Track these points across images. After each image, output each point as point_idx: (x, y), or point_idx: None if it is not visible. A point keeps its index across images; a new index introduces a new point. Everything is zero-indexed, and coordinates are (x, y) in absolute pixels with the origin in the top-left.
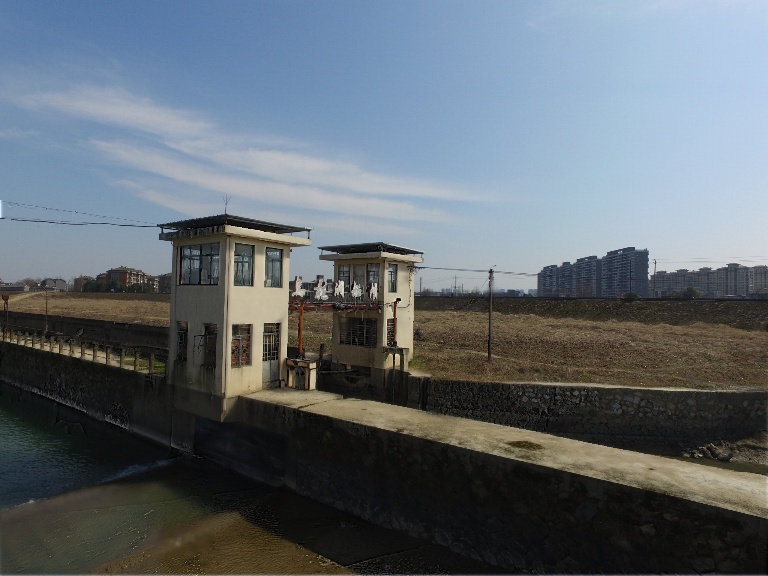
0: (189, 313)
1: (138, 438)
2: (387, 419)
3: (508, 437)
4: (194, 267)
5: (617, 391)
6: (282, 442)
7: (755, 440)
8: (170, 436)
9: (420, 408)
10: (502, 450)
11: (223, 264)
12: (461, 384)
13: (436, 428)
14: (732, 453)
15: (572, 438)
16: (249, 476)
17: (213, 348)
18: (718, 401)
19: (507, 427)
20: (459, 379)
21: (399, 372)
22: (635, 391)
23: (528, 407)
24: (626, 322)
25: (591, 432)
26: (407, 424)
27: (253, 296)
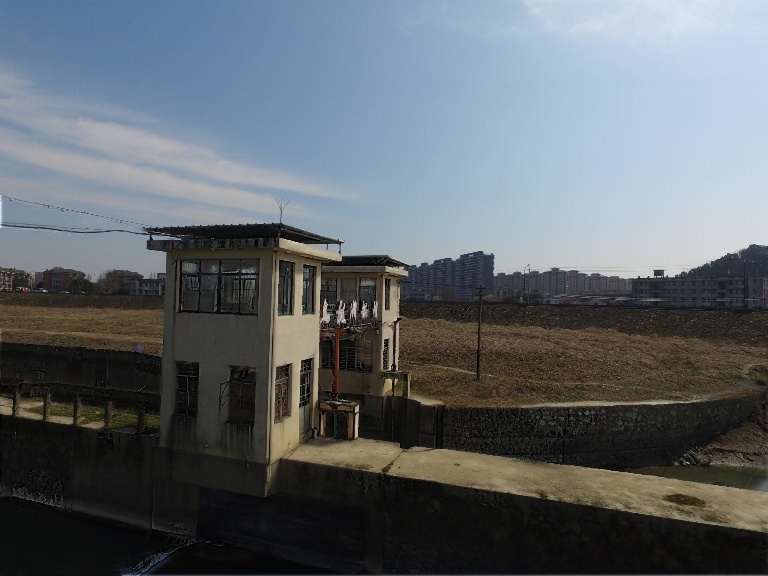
0: (201, 351)
1: (84, 519)
2: (504, 478)
3: (652, 490)
4: (192, 286)
5: (620, 408)
6: (359, 516)
7: (719, 443)
8: (150, 515)
9: (435, 440)
10: (678, 511)
11: (267, 288)
12: (480, 411)
13: (570, 486)
14: (710, 458)
15: (584, 458)
16: (304, 563)
17: (246, 399)
18: (692, 411)
19: (627, 474)
20: (477, 406)
21: (399, 399)
22: (633, 407)
23: (546, 430)
24: (528, 327)
25: (600, 450)
26: (534, 483)
27: (293, 327)
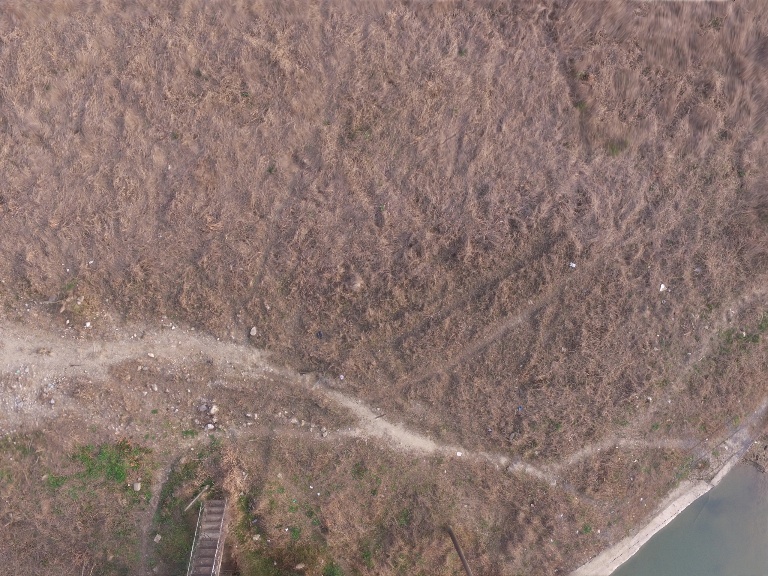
0: None
1: None
2: None
3: None
4: None
5: None
6: None
7: None
8: None
9: None
10: None
11: None
12: None
13: None
14: None
15: None
16: None
17: None
18: None
19: None
20: None
21: None
22: None
23: None
24: None
25: None
26: None
27: None
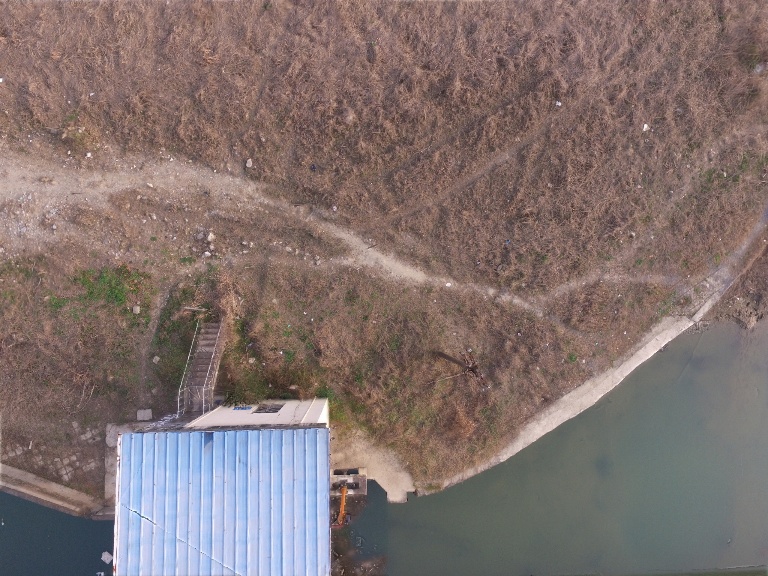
0: None
1: None
2: None
3: None
4: None
5: None
6: None
7: None
8: None
9: None
10: None
11: None
12: None
13: None
14: None
15: None
16: None
17: None
18: None
19: None
20: (453, 481)
21: None
22: None
23: None
24: None
25: None
26: None
27: None
